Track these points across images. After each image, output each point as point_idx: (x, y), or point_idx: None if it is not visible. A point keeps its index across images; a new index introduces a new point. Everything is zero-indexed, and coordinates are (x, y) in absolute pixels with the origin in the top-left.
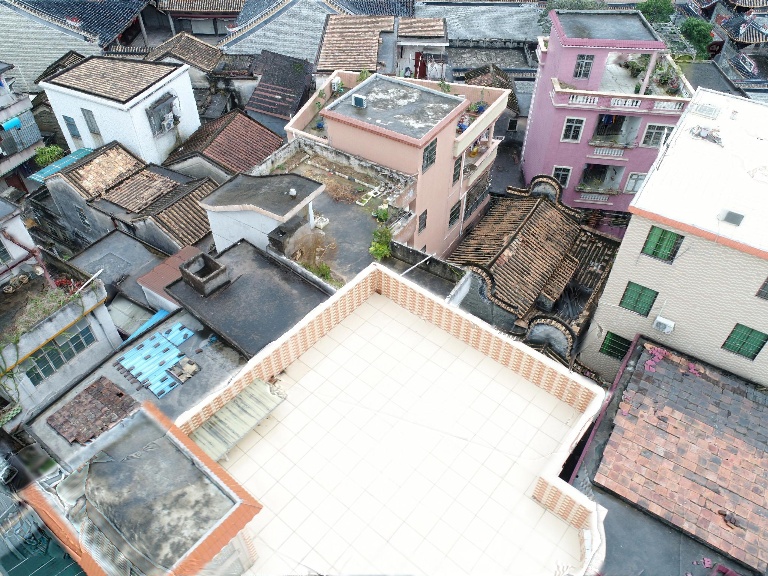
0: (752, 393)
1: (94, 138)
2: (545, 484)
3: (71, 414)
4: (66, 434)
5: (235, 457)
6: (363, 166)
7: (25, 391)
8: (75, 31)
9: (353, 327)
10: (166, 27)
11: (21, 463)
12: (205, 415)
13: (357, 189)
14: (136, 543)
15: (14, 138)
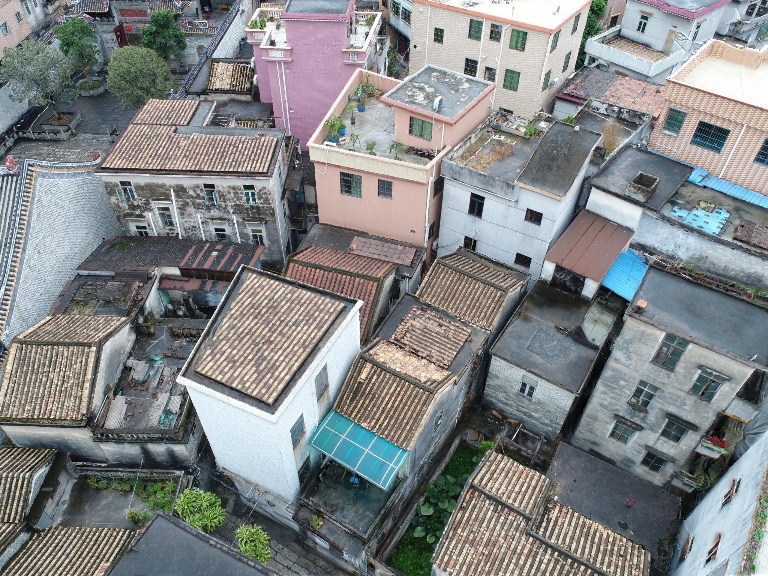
0: (586, 74)
1: (320, 404)
2: (759, 57)
3: None
4: None
5: None
6: None
7: None
8: None
9: None
10: None
11: None
12: None
13: (497, 144)
14: None
15: None
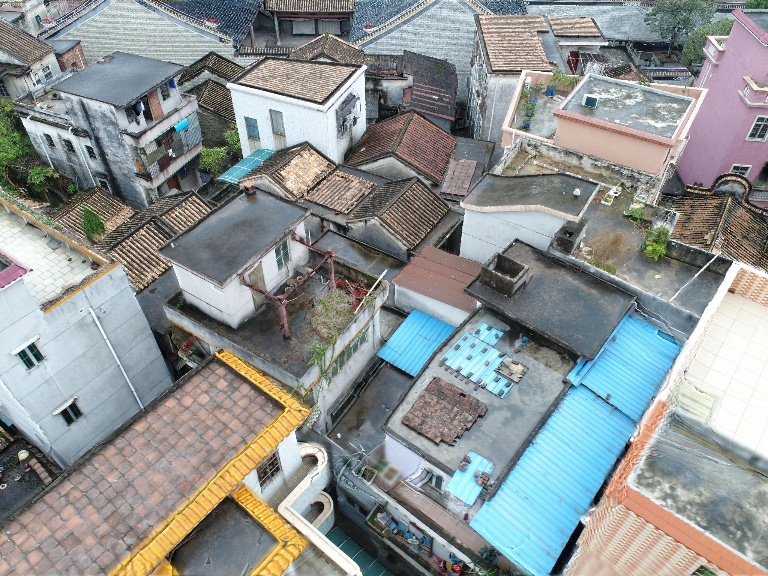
0: None
1: (276, 139)
2: None
3: (424, 414)
4: (430, 434)
5: (730, 455)
6: (597, 166)
7: (322, 392)
8: (212, 32)
9: (726, 326)
10: (266, 28)
11: (378, 463)
12: (669, 414)
13: None
14: (735, 540)
15: (182, 140)
